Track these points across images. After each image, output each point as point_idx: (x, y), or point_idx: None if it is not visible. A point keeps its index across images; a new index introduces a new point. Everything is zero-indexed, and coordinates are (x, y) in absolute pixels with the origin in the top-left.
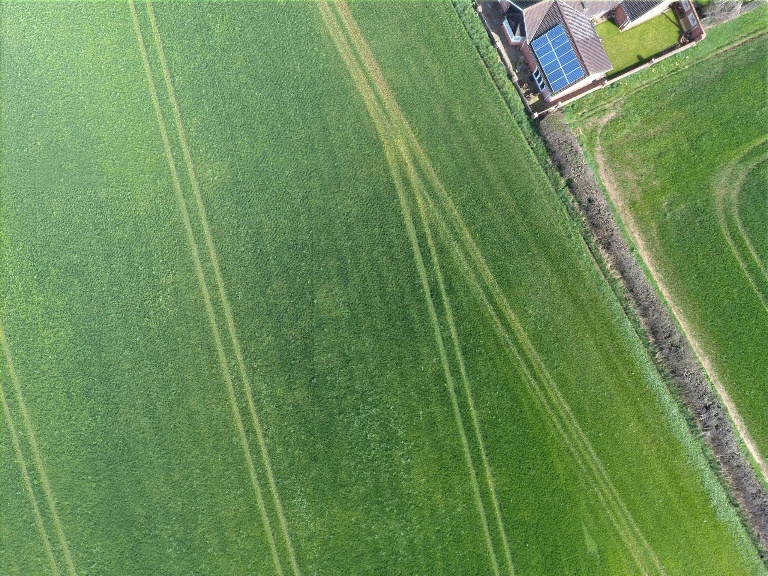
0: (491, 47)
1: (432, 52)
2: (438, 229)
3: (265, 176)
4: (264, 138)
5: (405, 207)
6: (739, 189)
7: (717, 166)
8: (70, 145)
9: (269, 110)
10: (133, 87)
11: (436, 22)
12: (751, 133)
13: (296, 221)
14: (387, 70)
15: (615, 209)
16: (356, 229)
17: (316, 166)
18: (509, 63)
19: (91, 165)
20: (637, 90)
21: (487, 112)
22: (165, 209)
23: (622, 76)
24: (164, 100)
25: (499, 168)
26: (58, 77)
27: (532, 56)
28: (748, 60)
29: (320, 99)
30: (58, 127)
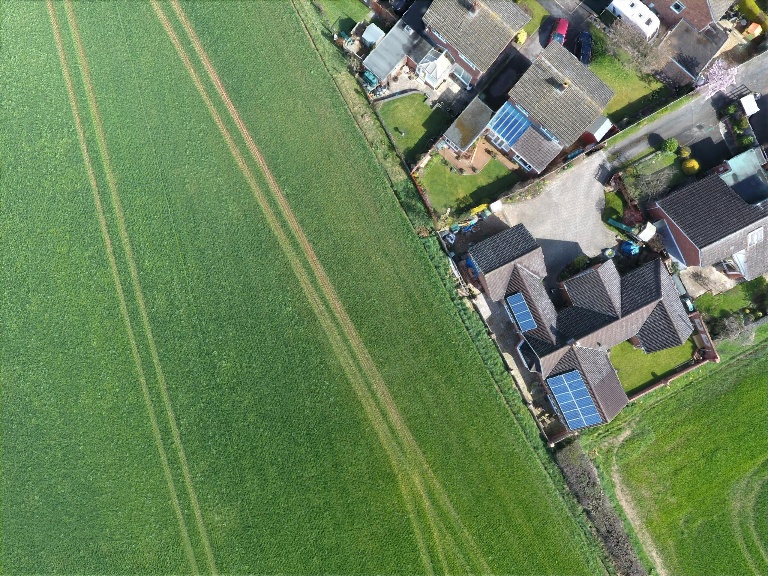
0: (505, 373)
1: (445, 377)
2: (455, 561)
3: (276, 518)
4: (274, 479)
5: (421, 540)
6: (754, 501)
7: (732, 480)
8: (70, 497)
9: (279, 449)
10: (136, 433)
11: (449, 347)
12: (765, 445)
13: (309, 564)
14: (400, 399)
15: (632, 530)
16: (371, 567)
17: (329, 505)
18: (523, 384)
19: (93, 518)
20: (652, 406)
21: (502, 439)
22: (172, 560)
23: (637, 397)
24: (169, 445)
25: (516, 495)
26: (56, 426)
27: (548, 391)
28: (760, 370)
29: (332, 435)
30: (57, 479)
